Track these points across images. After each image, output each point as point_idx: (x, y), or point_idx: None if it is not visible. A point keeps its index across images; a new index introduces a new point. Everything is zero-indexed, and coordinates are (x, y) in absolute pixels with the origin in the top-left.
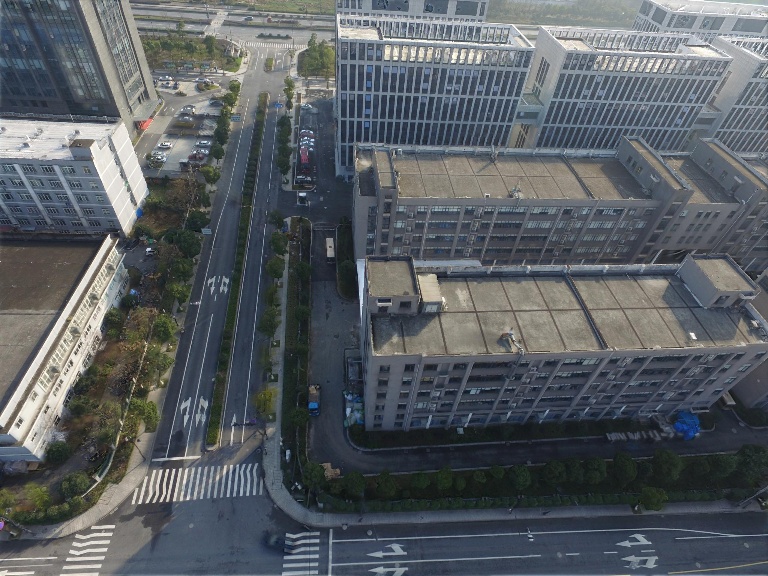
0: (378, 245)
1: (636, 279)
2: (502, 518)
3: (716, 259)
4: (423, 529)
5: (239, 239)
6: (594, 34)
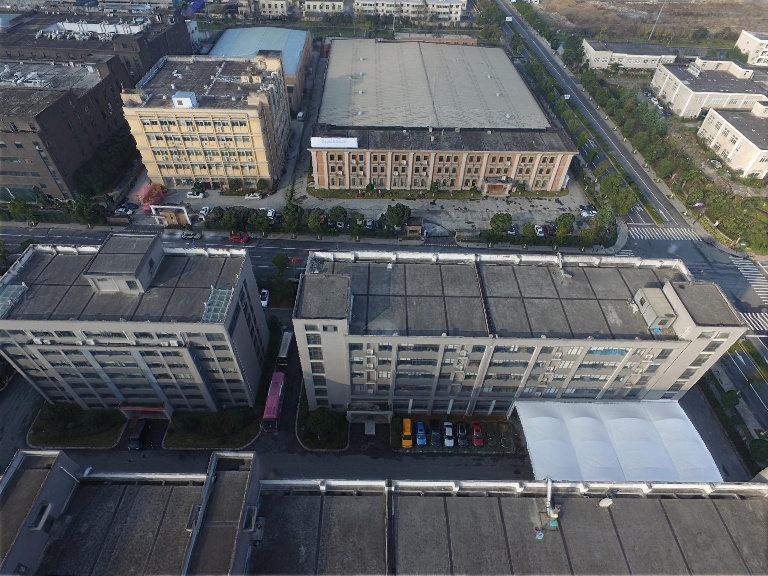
0: None
1: (406, 331)
2: None
3: (310, 318)
4: None
5: None
6: None
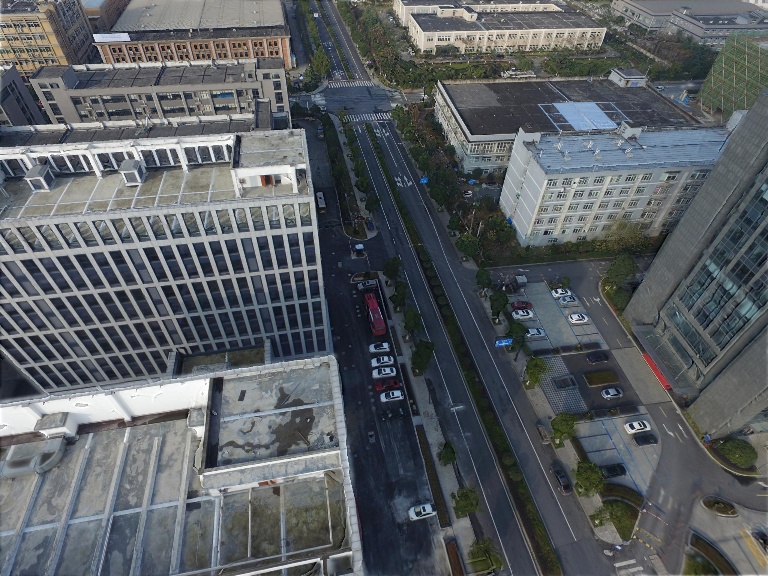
0: None
1: None
2: None
3: None
4: None
5: None
6: None
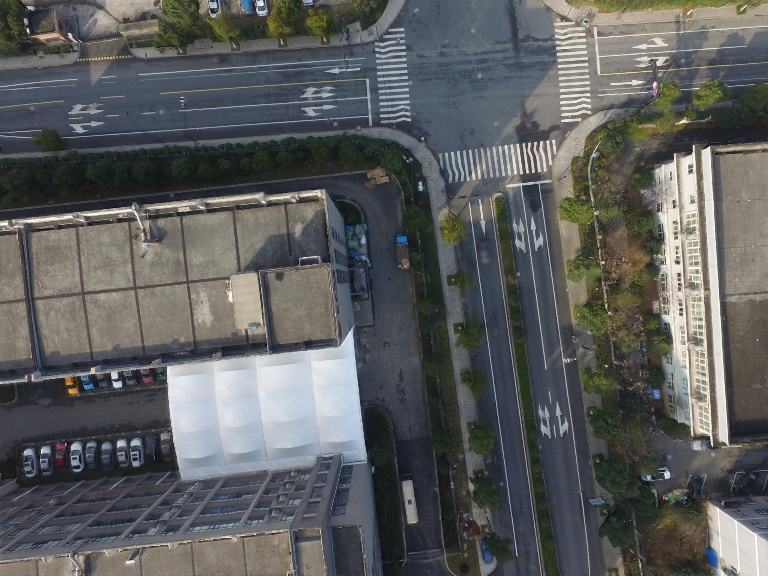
0: (333, 471)
1: None
2: (210, 141)
3: None
4: (286, 129)
5: (548, 514)
6: None
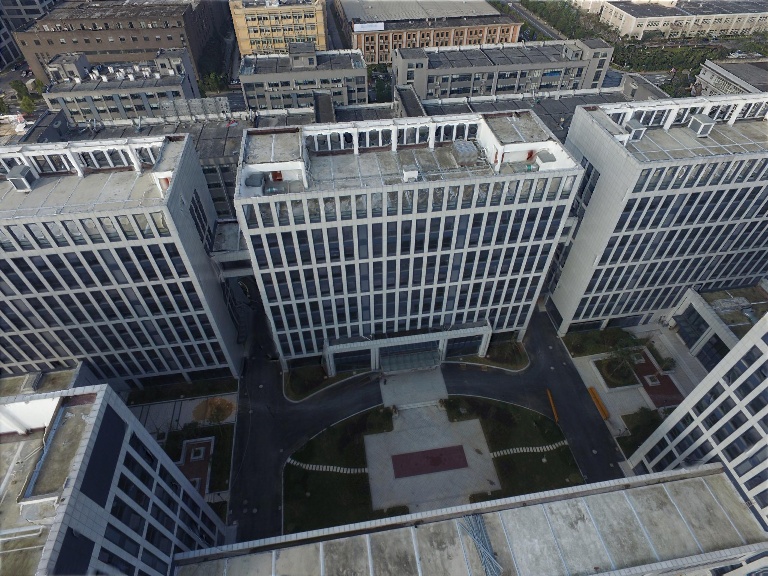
0: None
1: None
2: None
3: None
4: None
5: None
6: (466, 186)
